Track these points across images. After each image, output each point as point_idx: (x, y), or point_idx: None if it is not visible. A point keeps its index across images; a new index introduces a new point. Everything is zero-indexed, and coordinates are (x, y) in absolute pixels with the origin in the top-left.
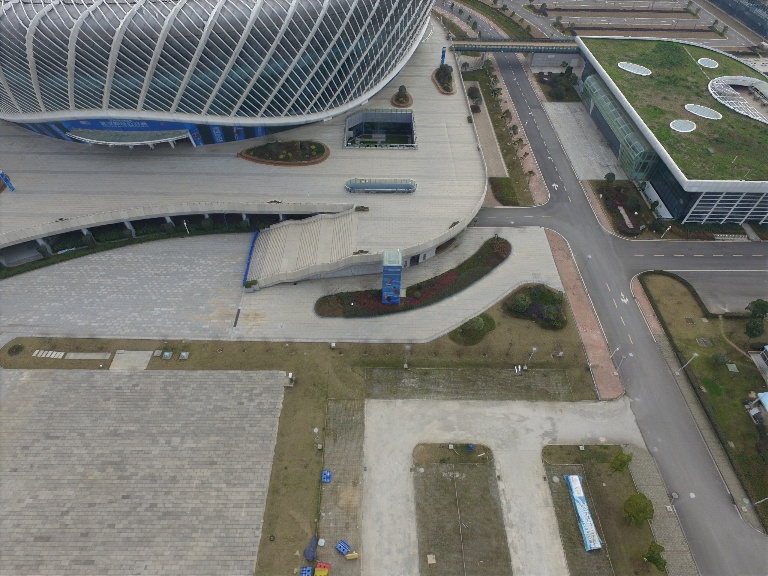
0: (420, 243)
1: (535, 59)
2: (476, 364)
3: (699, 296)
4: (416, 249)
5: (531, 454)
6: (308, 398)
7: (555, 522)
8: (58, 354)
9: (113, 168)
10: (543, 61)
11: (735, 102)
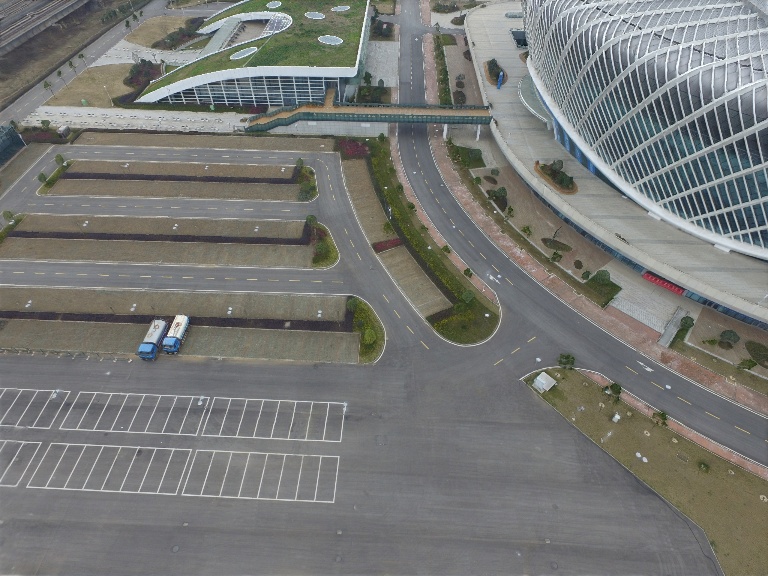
0: (500, 0)
1: None
2: None
3: None
4: (501, 2)
5: None
6: None
7: None
8: None
9: None
10: None
11: None
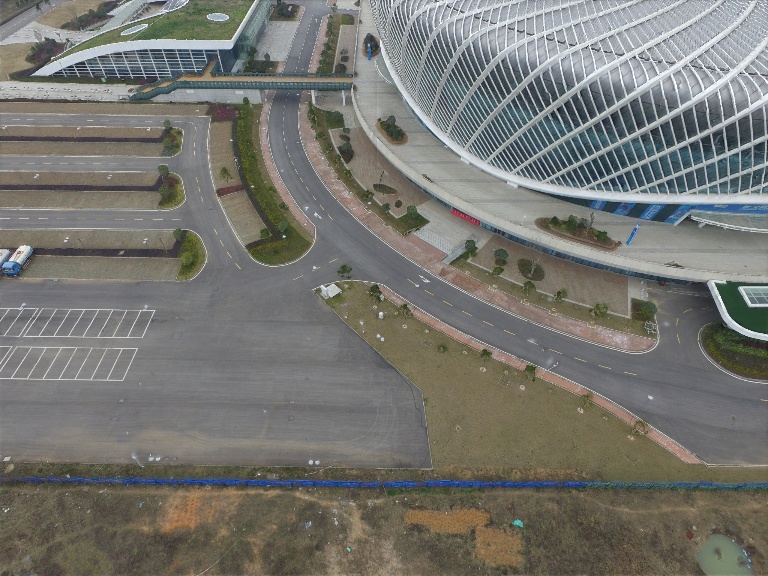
0: None
1: None
2: None
3: None
4: None
5: None
6: None
7: None
8: None
9: None
10: None
11: None
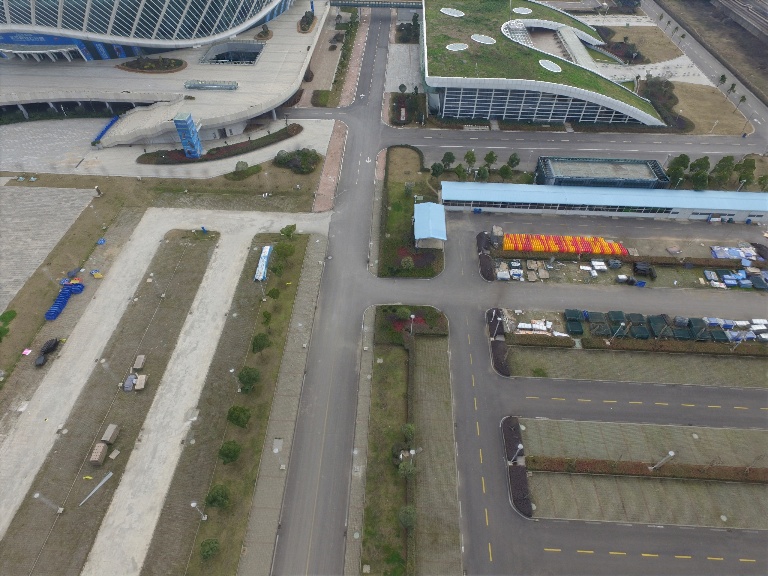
0: (218, 116)
1: (400, 14)
2: (236, 192)
3: (424, 159)
4: (216, 121)
5: (246, 237)
6: (108, 204)
7: (242, 268)
8: None
9: (20, 72)
10: (407, 15)
11: (518, 35)
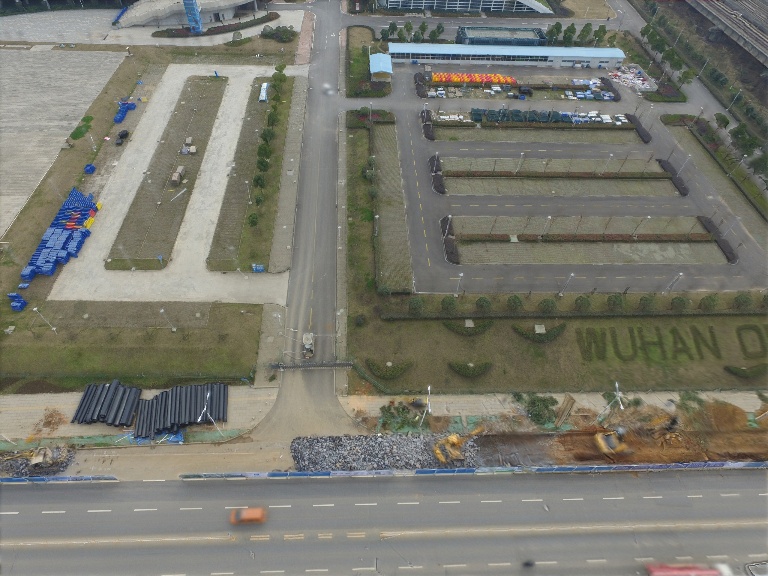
0: (214, 1)
1: None
2: (235, 54)
3: (375, 33)
4: (212, 5)
5: (248, 79)
6: (138, 61)
7: (248, 95)
8: (1, 45)
9: None
10: None
11: None
